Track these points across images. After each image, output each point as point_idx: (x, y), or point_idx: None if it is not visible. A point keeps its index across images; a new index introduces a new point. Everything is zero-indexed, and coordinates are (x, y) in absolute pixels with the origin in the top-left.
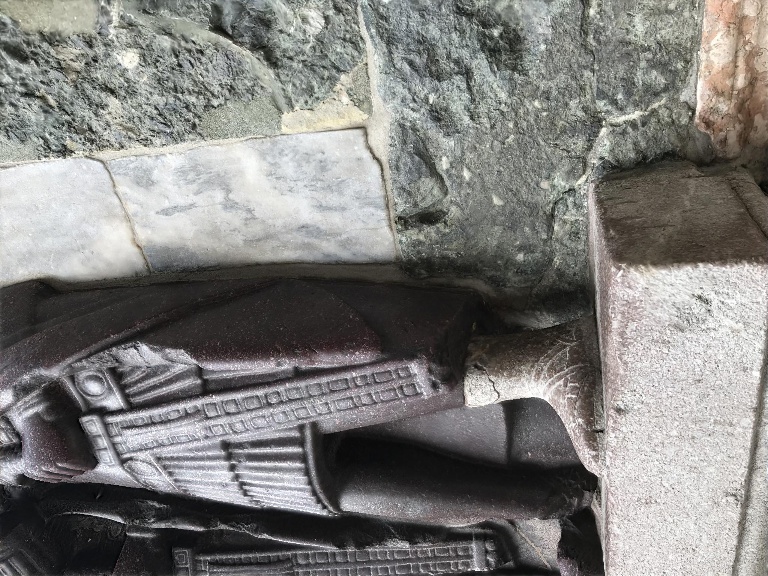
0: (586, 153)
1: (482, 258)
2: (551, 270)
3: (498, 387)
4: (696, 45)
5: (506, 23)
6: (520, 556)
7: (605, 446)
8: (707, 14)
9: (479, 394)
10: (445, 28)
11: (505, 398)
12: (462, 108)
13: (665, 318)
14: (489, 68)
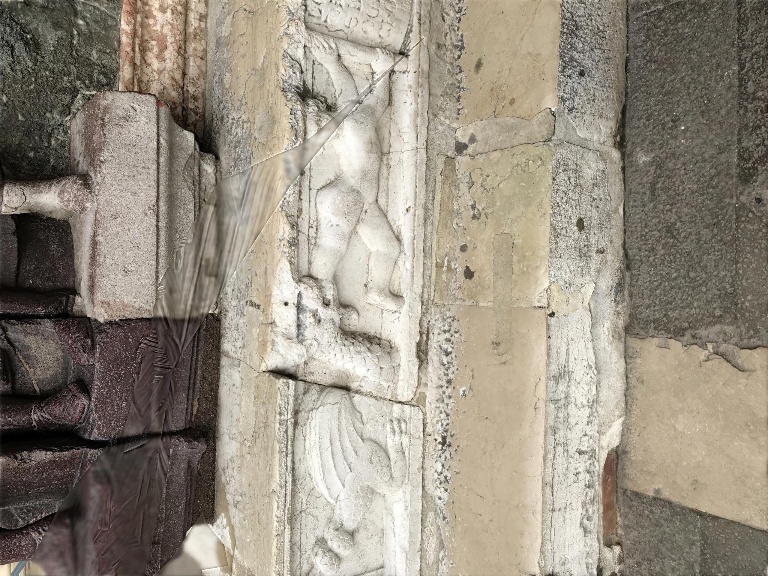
0: (70, 105)
1: (8, 150)
2: (49, 166)
3: (26, 192)
4: (118, 71)
5: (34, 35)
6: (16, 384)
7: (95, 187)
8: (121, 58)
9: (13, 196)
10: (4, 23)
11: (29, 203)
12: (7, 64)
13: (120, 114)
14: (25, 49)
